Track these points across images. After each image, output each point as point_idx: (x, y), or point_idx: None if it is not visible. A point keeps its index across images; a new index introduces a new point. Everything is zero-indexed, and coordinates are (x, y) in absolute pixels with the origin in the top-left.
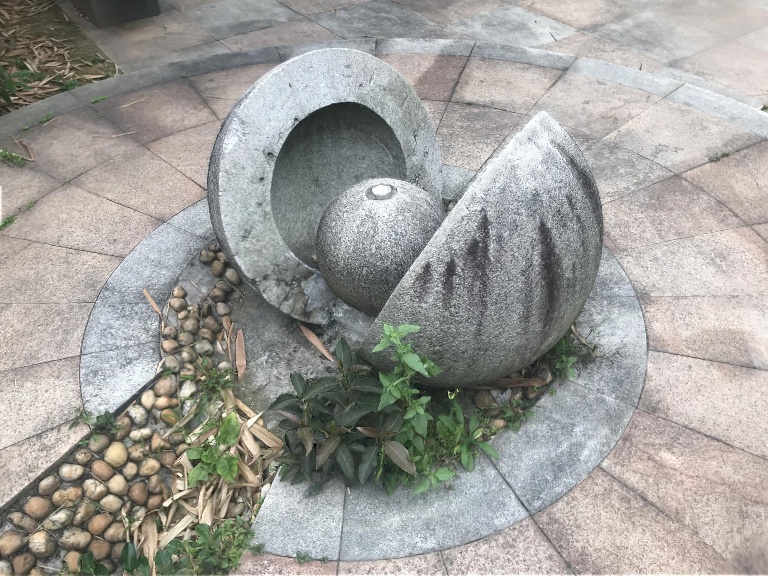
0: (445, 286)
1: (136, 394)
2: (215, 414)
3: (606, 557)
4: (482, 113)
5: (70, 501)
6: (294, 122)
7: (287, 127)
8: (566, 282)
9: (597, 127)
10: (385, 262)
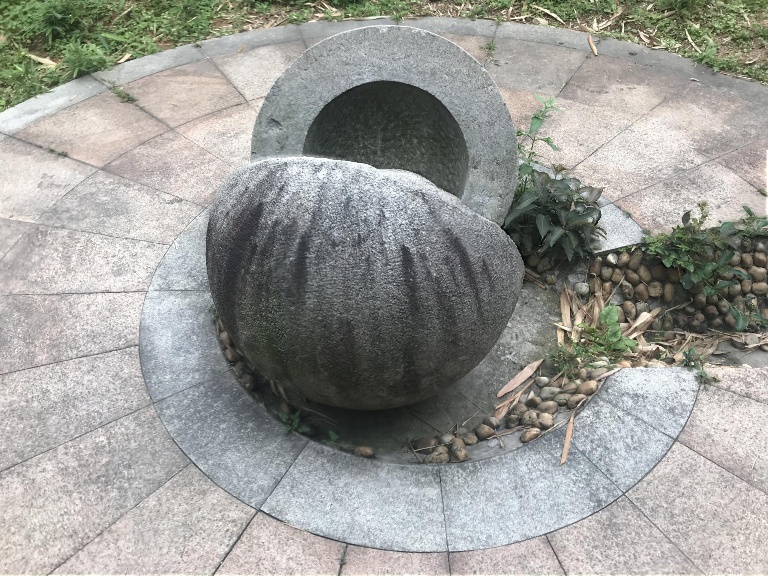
0: None
1: None
2: None
3: None
4: None
5: None
6: None
7: None
8: None
9: (3, 233)
10: None
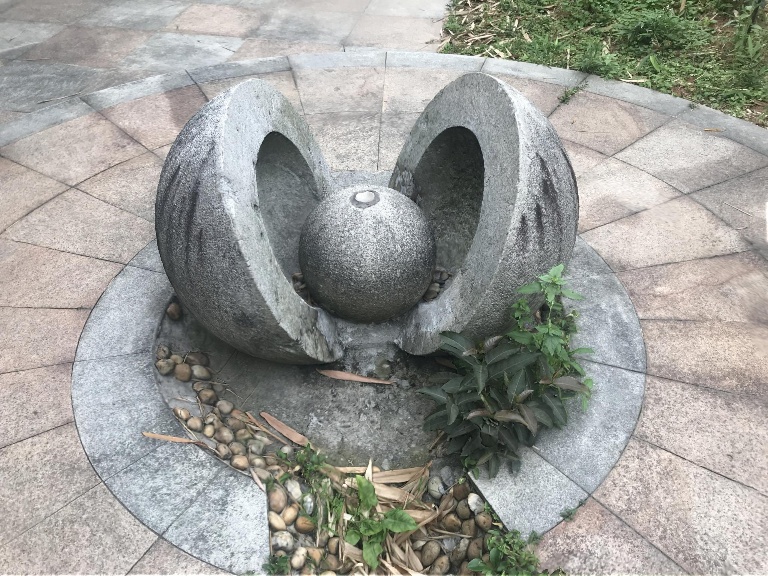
0: (538, 230)
1: None
2: (330, 494)
3: (704, 365)
4: None
5: None
6: (253, 167)
7: (253, 173)
8: None
9: (368, 104)
10: (412, 256)
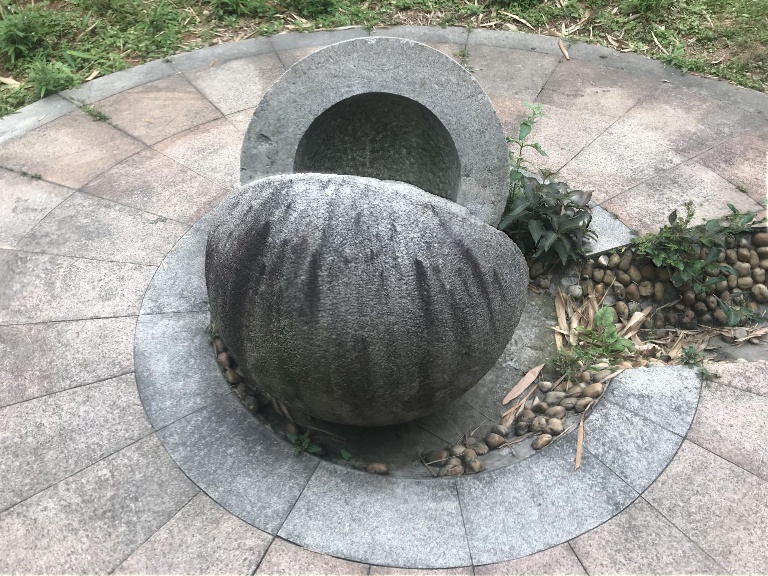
0: None
1: None
2: None
3: None
4: None
5: None
6: None
7: None
8: None
9: None
10: None
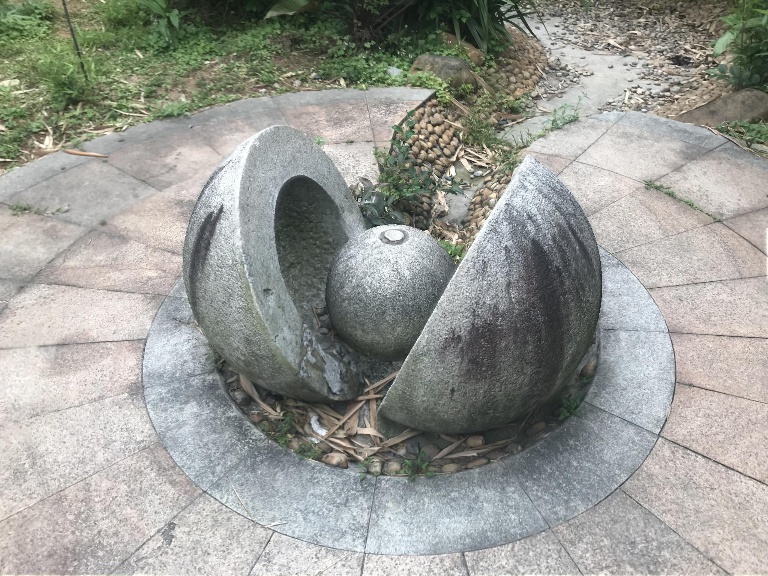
0: None
1: None
2: None
3: None
4: None
5: None
6: None
7: None
8: None
9: None
10: None
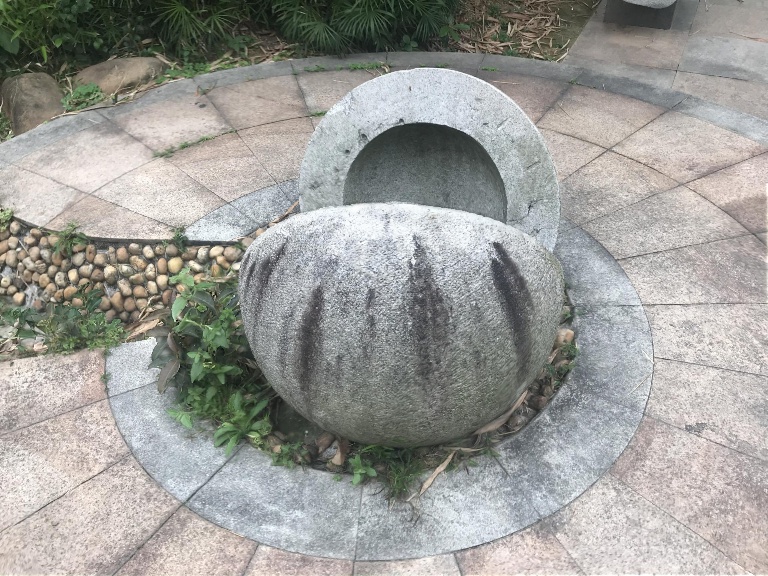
0: (247, 280)
1: (211, 242)
2: None
3: (157, 575)
4: (766, 266)
5: (137, 266)
6: (400, 122)
7: (390, 122)
8: (326, 364)
9: None
10: None
